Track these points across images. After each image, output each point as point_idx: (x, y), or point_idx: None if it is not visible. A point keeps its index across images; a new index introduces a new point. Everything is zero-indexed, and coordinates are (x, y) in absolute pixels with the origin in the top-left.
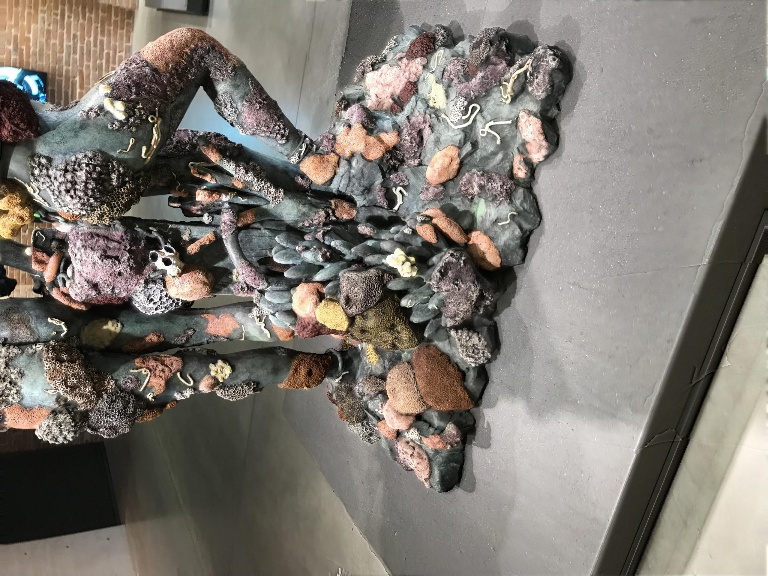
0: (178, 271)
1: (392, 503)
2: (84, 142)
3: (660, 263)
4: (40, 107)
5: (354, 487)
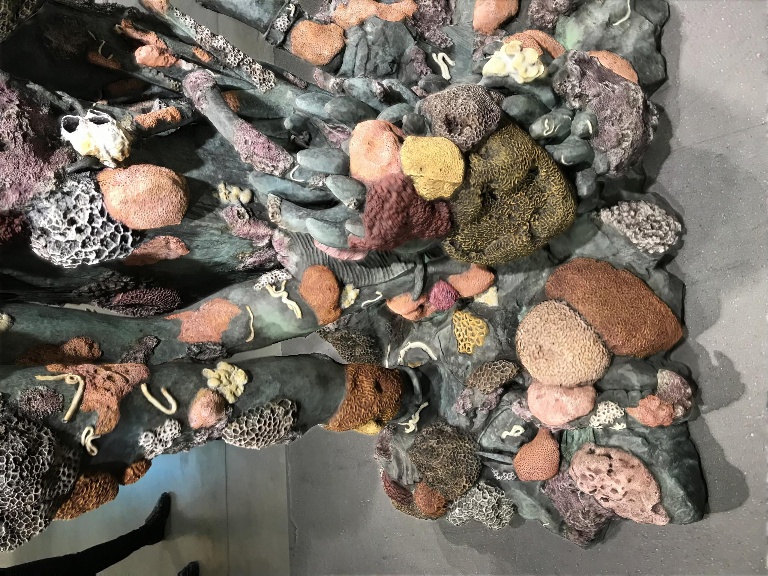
0: (122, 143)
1: None
2: None
3: None
4: None
5: None
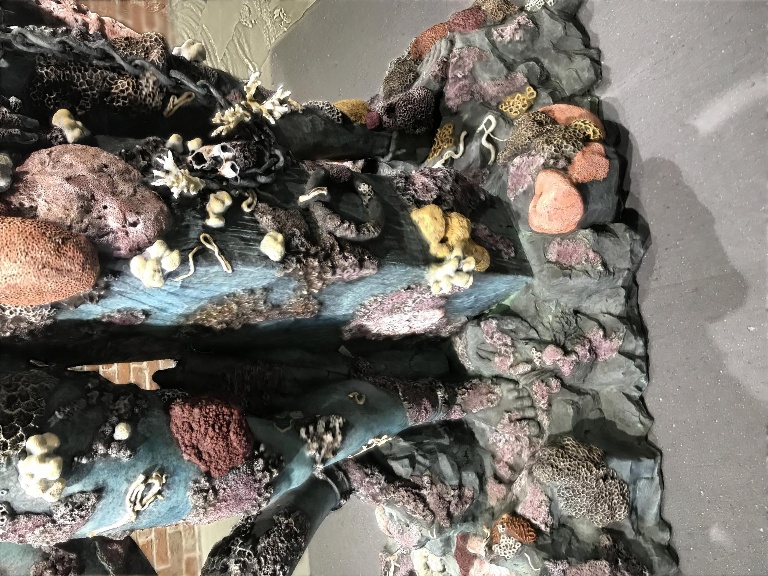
0: None
1: None
2: None
3: None
4: None
5: None
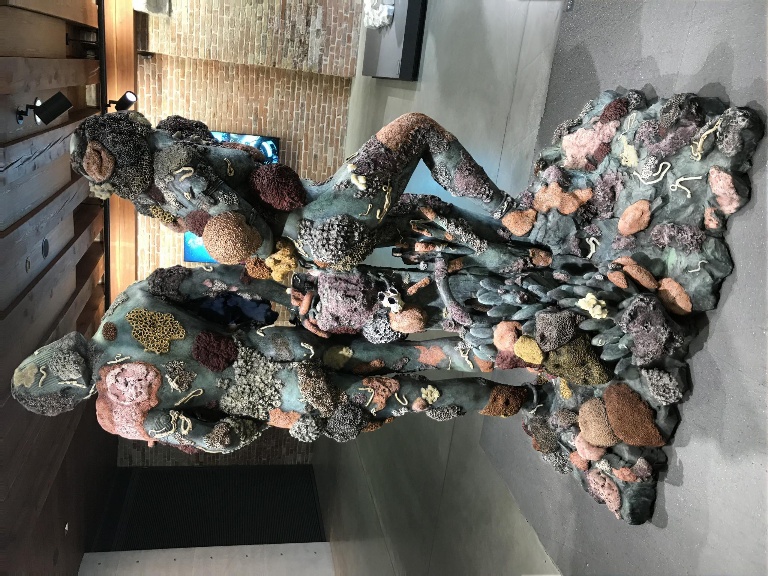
0: (400, 309)
1: (584, 535)
2: (336, 208)
3: None
4: (305, 183)
5: (547, 517)
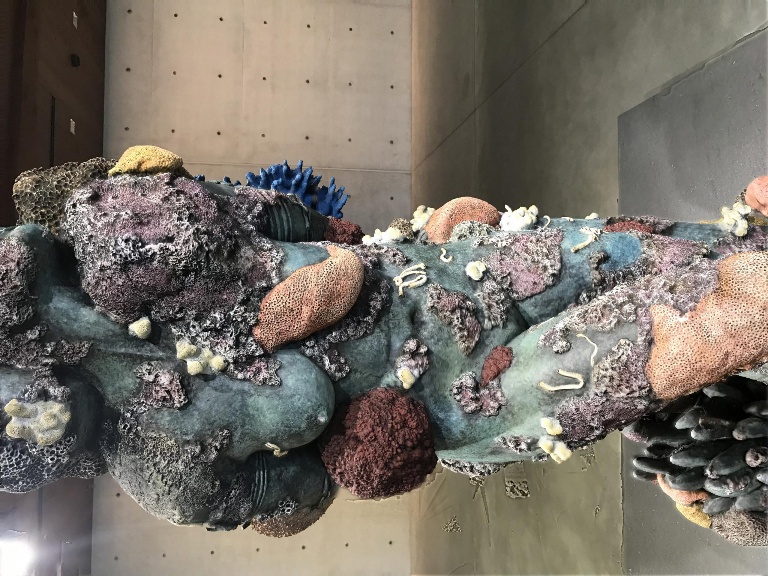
0: None
1: None
2: (489, 460)
3: None
4: (443, 382)
5: None
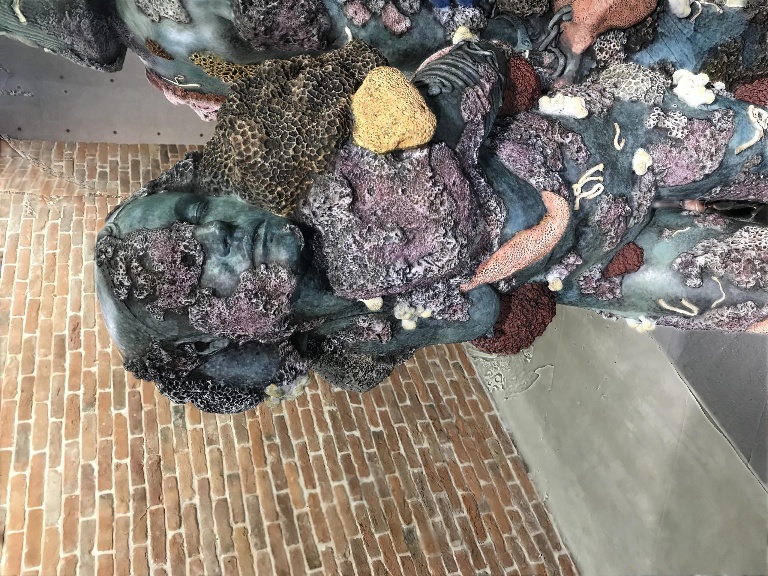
0: None
1: None
2: None
3: (759, 440)
4: None
5: None
